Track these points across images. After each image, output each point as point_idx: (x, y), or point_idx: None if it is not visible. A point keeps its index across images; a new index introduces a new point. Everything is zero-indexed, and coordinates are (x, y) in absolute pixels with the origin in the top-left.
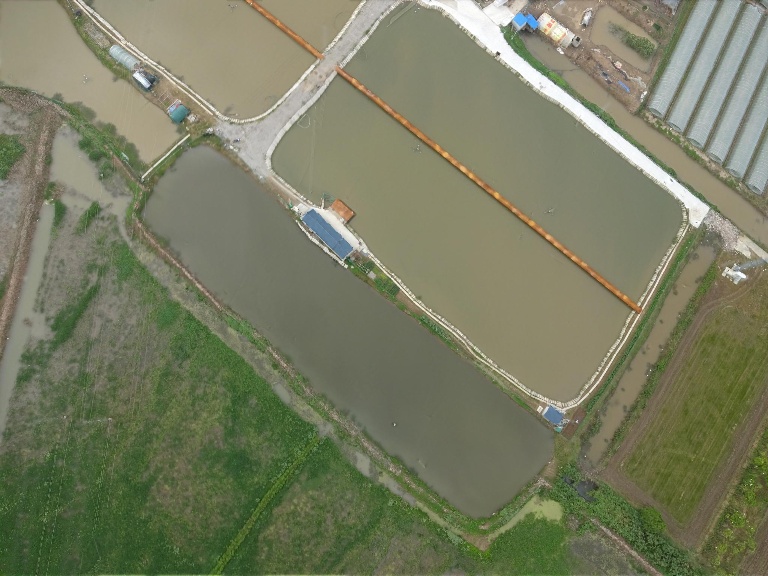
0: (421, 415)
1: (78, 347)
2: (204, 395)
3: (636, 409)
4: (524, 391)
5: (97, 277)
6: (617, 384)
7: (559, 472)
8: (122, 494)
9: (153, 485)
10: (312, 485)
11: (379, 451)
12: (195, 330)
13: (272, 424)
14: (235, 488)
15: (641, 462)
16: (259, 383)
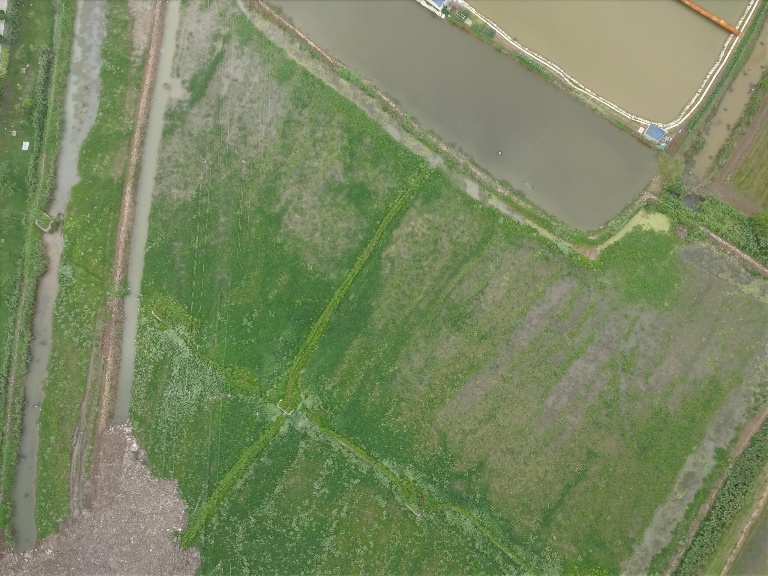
0: (524, 143)
1: (211, 104)
2: (323, 137)
3: (740, 126)
4: (624, 115)
5: (222, 45)
6: (719, 104)
7: (664, 186)
8: (259, 223)
9: (285, 215)
10: (427, 209)
11: (487, 175)
12: (311, 82)
13: (386, 158)
14: (357, 214)
15: (748, 175)
16: (371, 123)
